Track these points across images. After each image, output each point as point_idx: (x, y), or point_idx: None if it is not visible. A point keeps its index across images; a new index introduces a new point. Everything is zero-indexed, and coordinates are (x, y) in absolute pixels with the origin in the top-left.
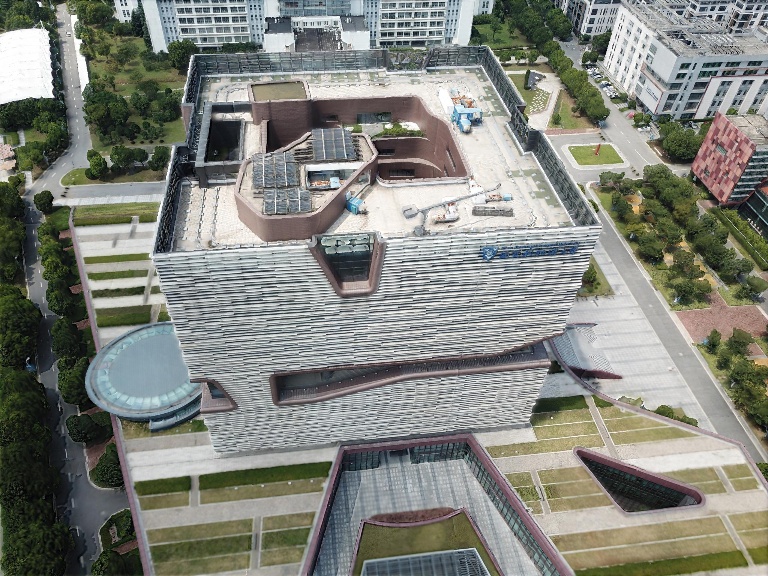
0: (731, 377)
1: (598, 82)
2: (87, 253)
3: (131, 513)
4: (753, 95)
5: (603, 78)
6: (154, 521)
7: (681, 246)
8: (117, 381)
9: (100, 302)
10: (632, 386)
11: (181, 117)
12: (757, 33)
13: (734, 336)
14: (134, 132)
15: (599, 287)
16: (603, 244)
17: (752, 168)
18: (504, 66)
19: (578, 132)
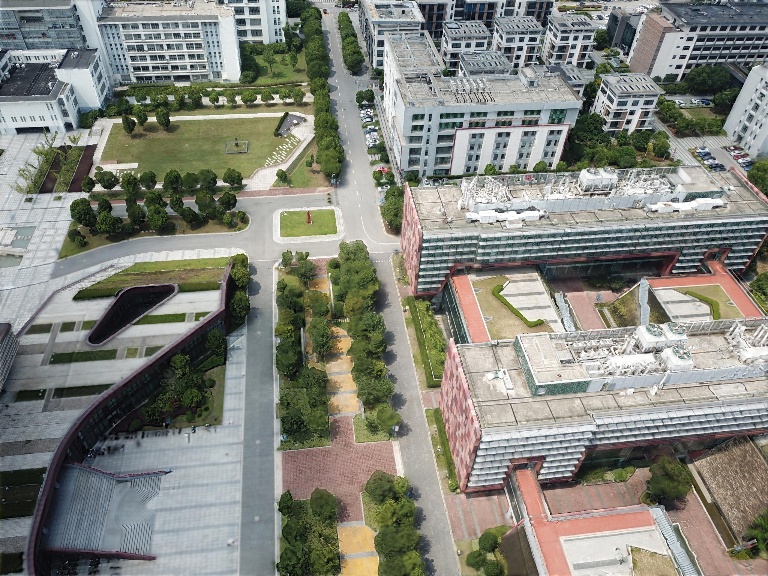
0: (277, 567)
1: (365, 127)
2: None
3: None
4: (515, 148)
5: (373, 122)
6: None
7: (342, 352)
8: None
9: None
10: (162, 572)
11: None
12: (521, 76)
13: (310, 501)
14: None
15: (204, 414)
16: (248, 349)
17: (431, 256)
18: (267, 106)
19: (305, 192)
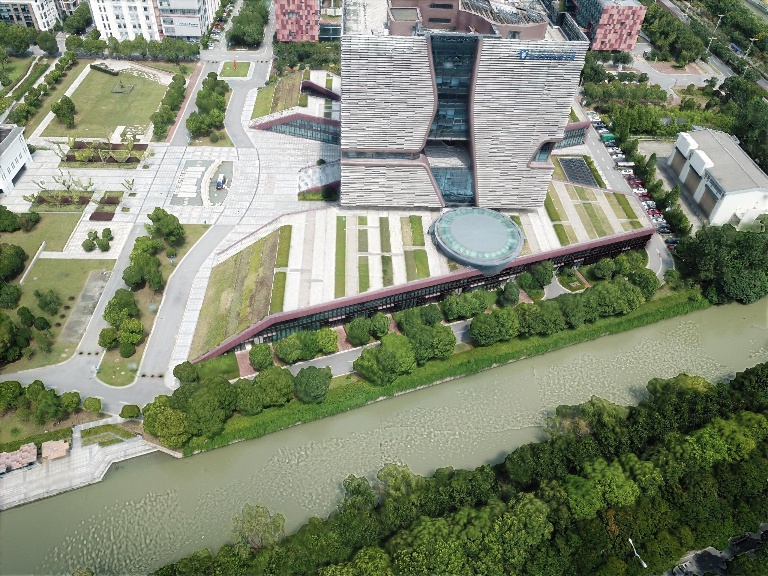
0: None
1: None
2: (328, 297)
3: (582, 245)
4: None
5: None
6: (584, 237)
7: None
8: (496, 247)
9: (399, 280)
10: None
11: (20, 282)
12: None
13: None
14: (32, 324)
15: None
16: None
17: None
18: (64, 76)
19: (200, 69)
